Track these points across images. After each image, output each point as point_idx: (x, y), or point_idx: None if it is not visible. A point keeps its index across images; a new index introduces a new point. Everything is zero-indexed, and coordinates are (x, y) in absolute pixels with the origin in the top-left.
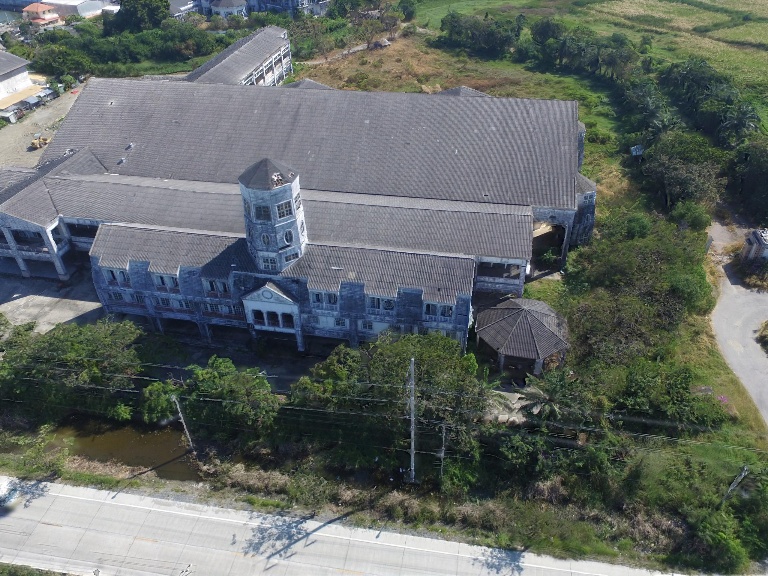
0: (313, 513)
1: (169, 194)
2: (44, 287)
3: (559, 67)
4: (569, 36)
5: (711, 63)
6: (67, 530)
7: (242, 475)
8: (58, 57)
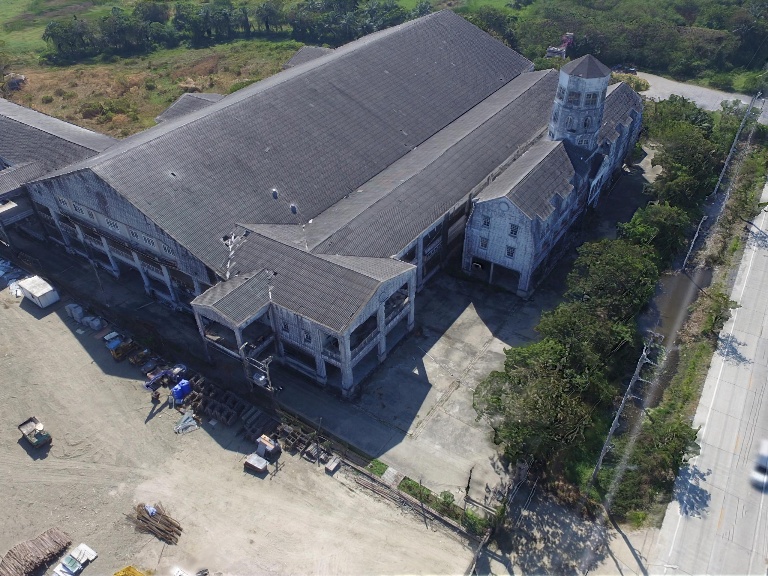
0: (745, 228)
1: (417, 182)
2: (412, 348)
3: (216, 38)
4: (206, 8)
5: (289, 2)
6: (767, 324)
7: (712, 250)
8: None
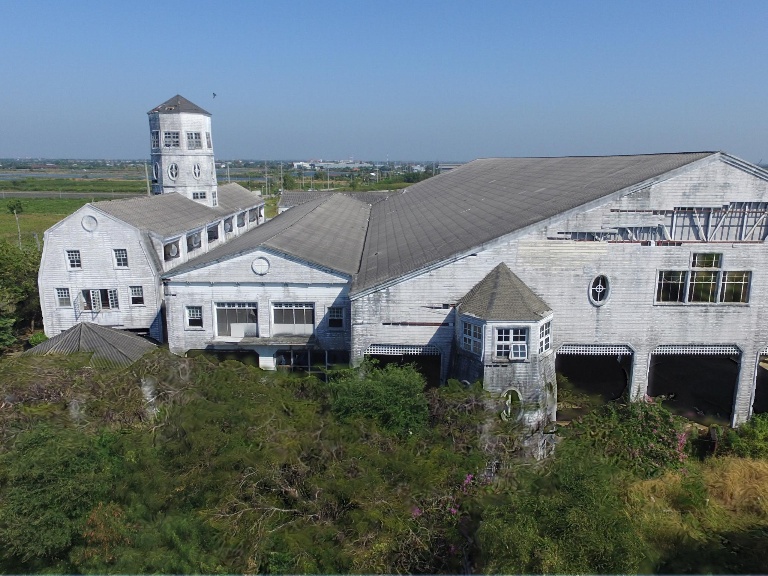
0: None
1: None
2: None
3: None
4: None
5: None
6: None
7: None
8: None
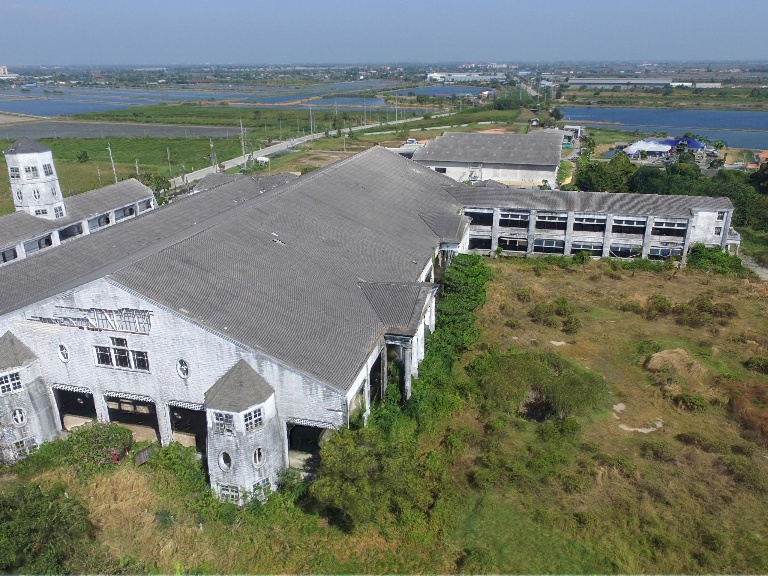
0: None
1: None
2: None
3: None
4: None
5: None
6: None
7: None
8: (582, 169)
